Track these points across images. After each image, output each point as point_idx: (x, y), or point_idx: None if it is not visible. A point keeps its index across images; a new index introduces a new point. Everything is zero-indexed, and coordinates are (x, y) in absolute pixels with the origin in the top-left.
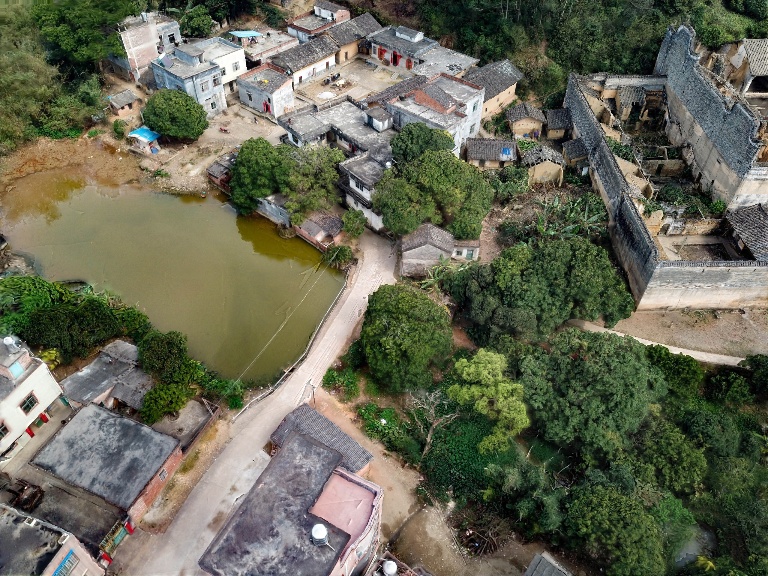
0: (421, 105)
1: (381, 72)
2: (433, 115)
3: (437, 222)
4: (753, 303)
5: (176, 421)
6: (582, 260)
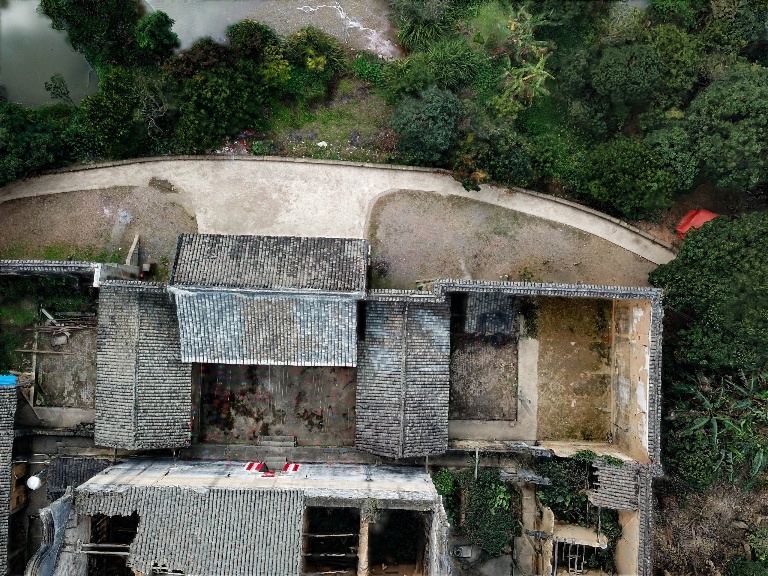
0: None
1: None
2: None
3: None
4: None
5: None
6: None
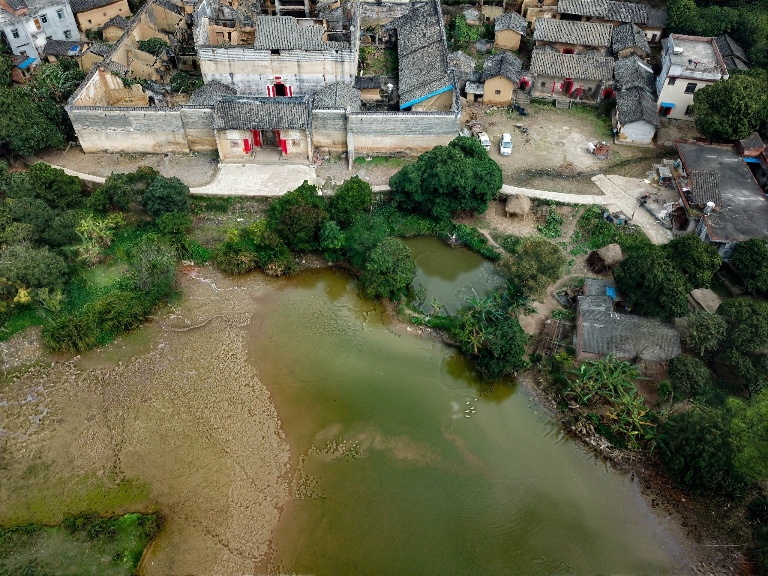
0: (4, 9)
1: None
2: (6, 16)
3: None
4: (171, 148)
5: None
6: None
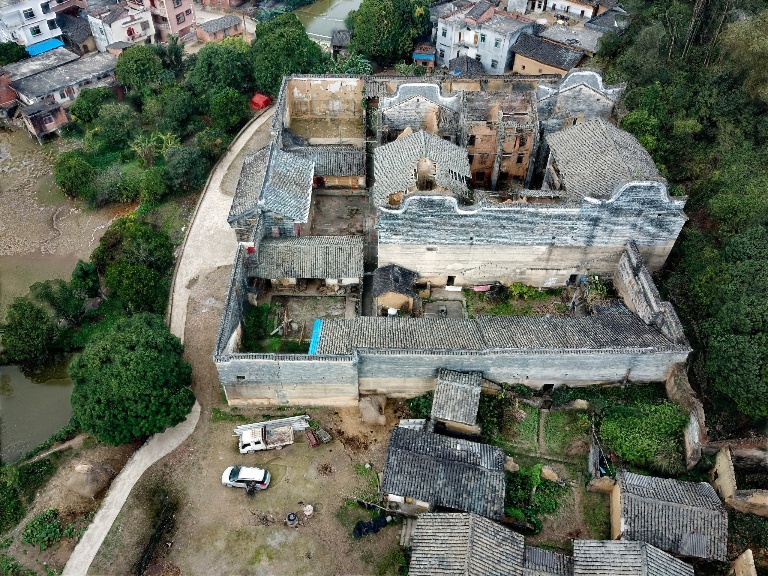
0: None
1: None
2: (463, 18)
3: None
4: None
5: (250, 7)
6: None
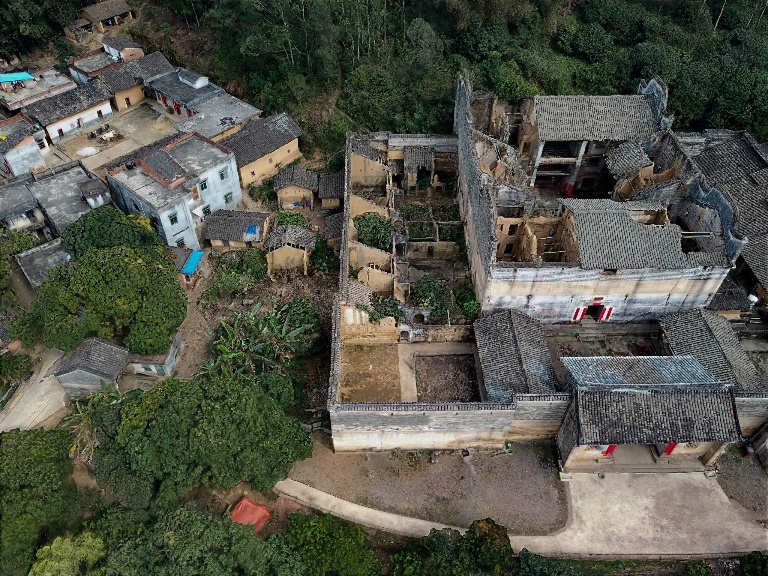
0: (148, 176)
1: (164, 121)
2: (155, 190)
3: (106, 336)
4: (476, 443)
5: None
6: (209, 414)
